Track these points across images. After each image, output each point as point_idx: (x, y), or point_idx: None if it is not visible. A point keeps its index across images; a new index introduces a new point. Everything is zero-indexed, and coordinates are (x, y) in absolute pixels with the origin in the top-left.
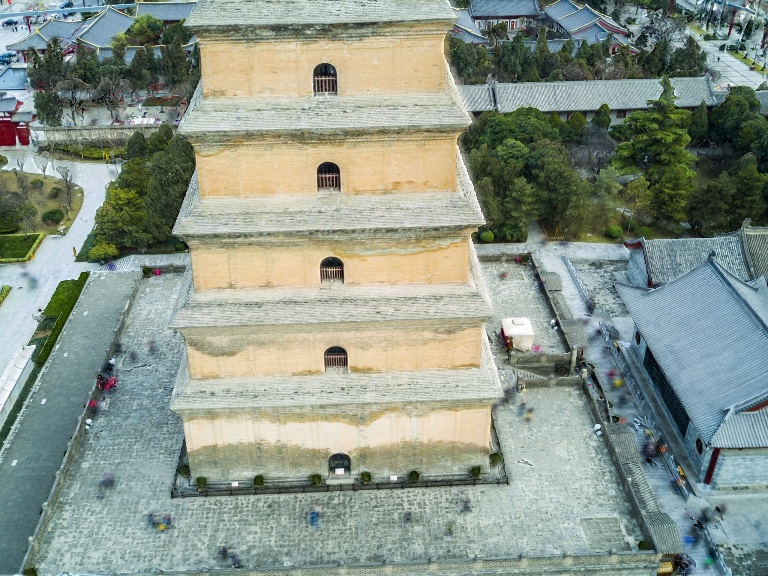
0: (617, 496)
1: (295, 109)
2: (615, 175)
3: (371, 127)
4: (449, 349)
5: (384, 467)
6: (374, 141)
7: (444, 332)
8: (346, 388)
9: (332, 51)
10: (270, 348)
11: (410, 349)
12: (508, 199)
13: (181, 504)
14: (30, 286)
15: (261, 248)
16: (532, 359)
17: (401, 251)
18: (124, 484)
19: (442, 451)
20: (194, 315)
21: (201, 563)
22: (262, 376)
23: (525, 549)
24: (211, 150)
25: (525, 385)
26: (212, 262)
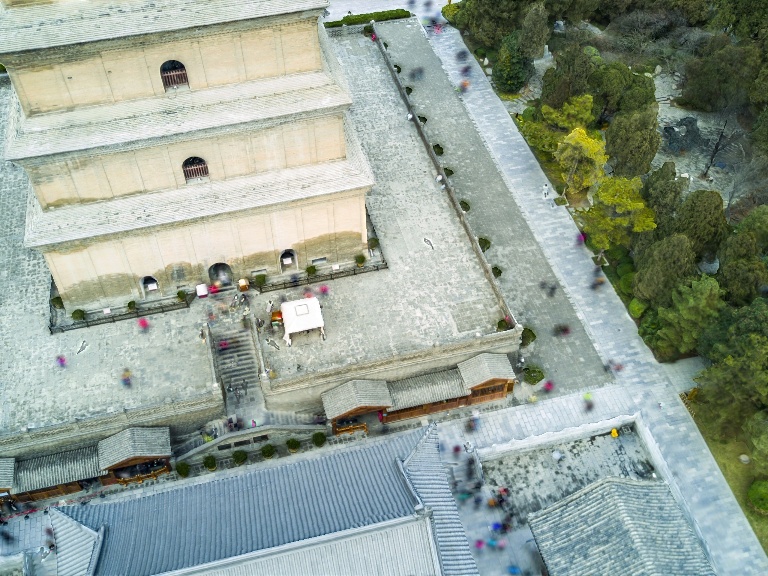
0: None
1: None
2: None
3: None
4: None
5: None
6: None
7: None
8: None
9: None
10: None
11: None
12: None
13: None
14: None
15: None
16: None
17: None
18: None
19: None
20: None
21: None
22: None
23: None
24: None
25: None
26: None
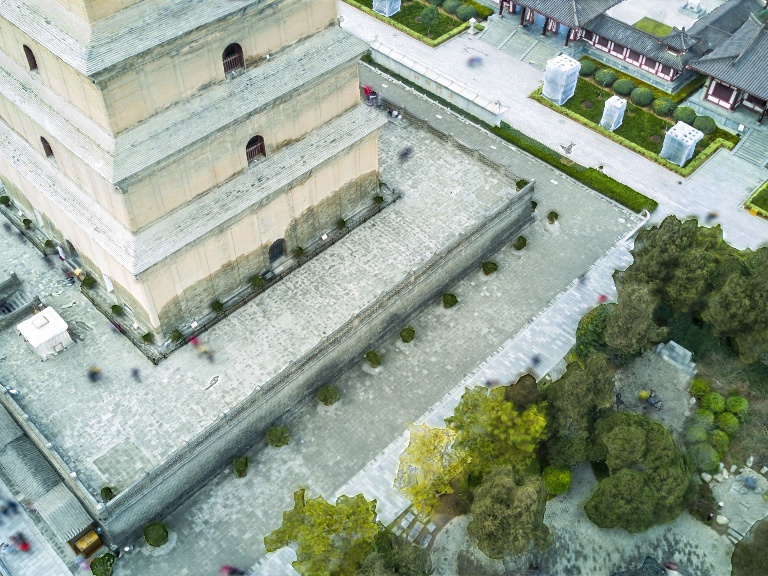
0: None
1: None
2: None
3: None
4: None
5: None
6: None
7: None
8: None
9: None
10: None
11: None
12: None
13: None
14: (678, 189)
15: None
16: None
17: None
18: None
19: None
20: None
21: None
22: None
23: None
24: None
25: None
26: None
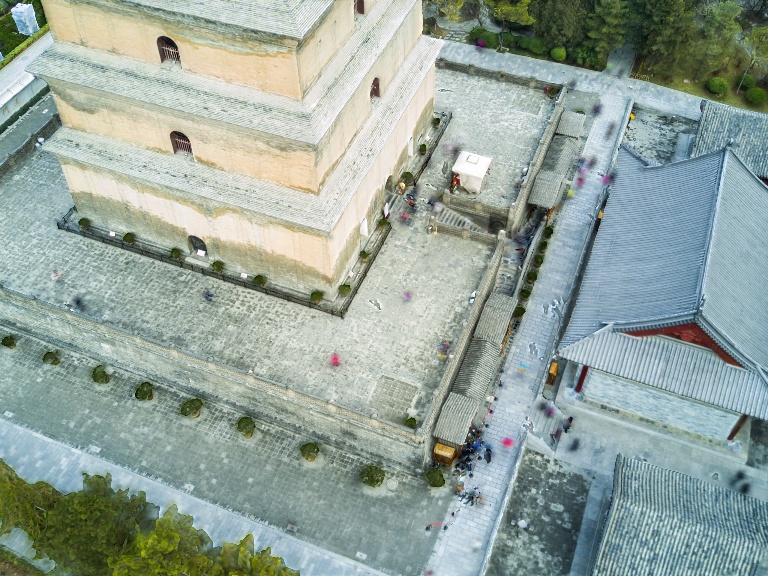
0: (437, 368)
1: None
2: (734, 13)
3: None
4: (284, 166)
5: (236, 262)
6: None
7: (276, 147)
8: (189, 176)
9: None
10: (122, 116)
11: (247, 155)
12: (593, 15)
13: (62, 236)
14: None
15: (100, 10)
16: (467, 203)
17: (230, 48)
18: (33, 204)
19: (286, 265)
20: (48, 64)
21: (44, 291)
22: (121, 141)
23: (308, 382)
24: None
25: (438, 228)
26: (62, 14)
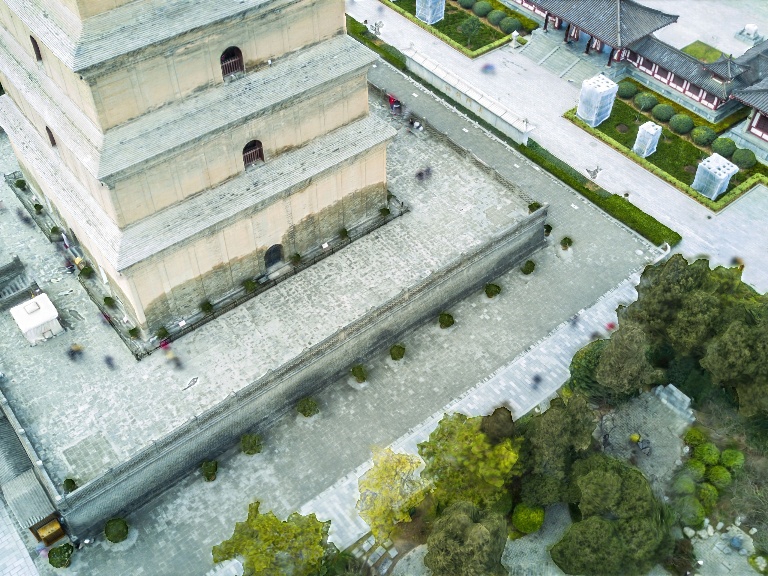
0: None
1: None
2: None
3: None
4: None
5: None
6: None
7: None
8: None
9: None
10: None
11: None
12: None
13: None
14: (706, 223)
15: None
16: None
17: None
18: None
19: None
20: None
21: None
22: None
23: None
24: None
25: None
26: None
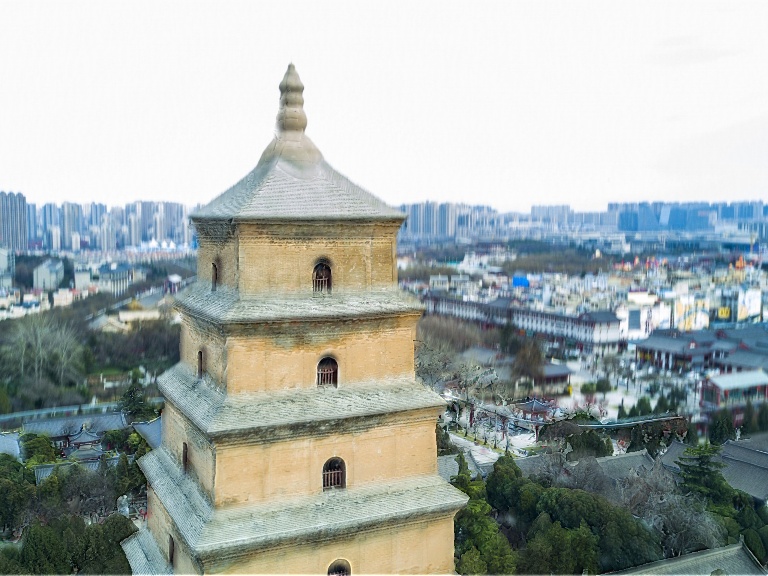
0: None
1: (309, 507)
2: None
3: (385, 515)
4: None
5: None
6: (383, 530)
7: None
8: None
9: (342, 444)
10: None
11: None
12: None
13: None
14: None
15: None
16: None
17: None
18: None
19: None
20: None
21: None
22: None
23: None
24: (221, 565)
25: None
26: None
